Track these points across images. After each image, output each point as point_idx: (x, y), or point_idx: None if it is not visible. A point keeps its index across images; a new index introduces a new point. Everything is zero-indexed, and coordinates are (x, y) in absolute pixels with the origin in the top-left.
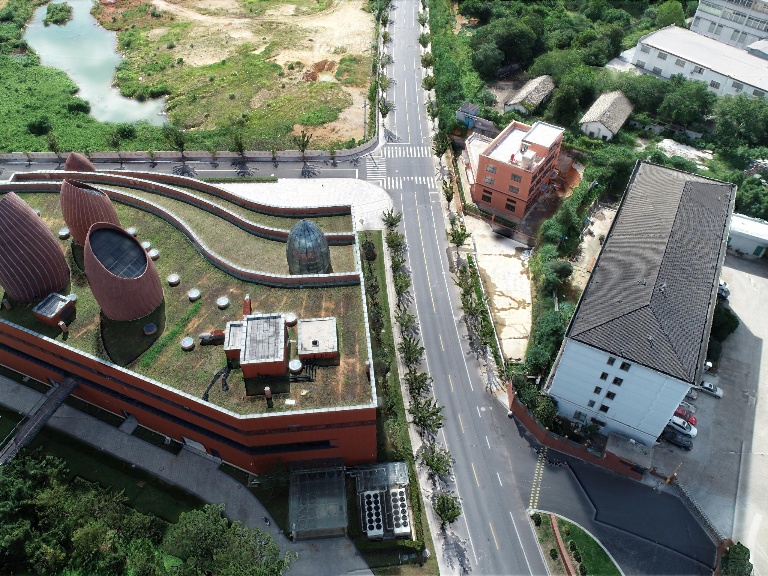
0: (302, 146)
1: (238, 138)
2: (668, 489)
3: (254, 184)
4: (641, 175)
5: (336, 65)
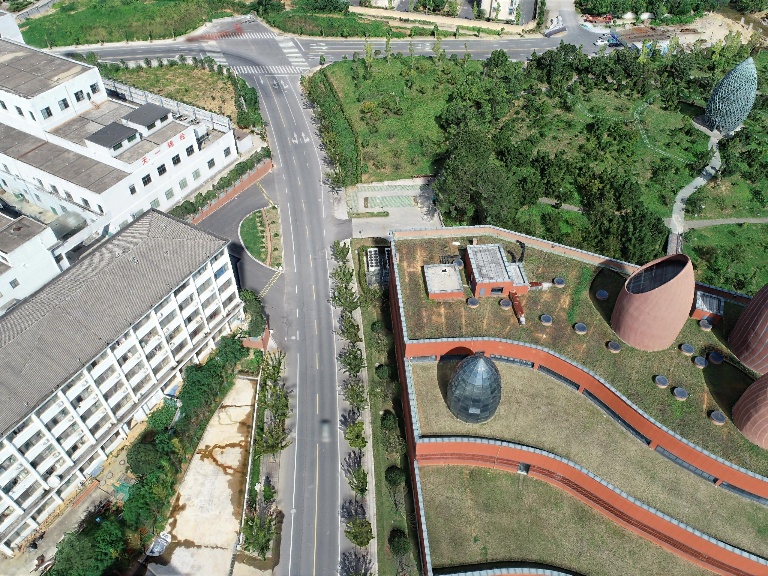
0: None
1: None
2: None
3: None
4: None
5: None
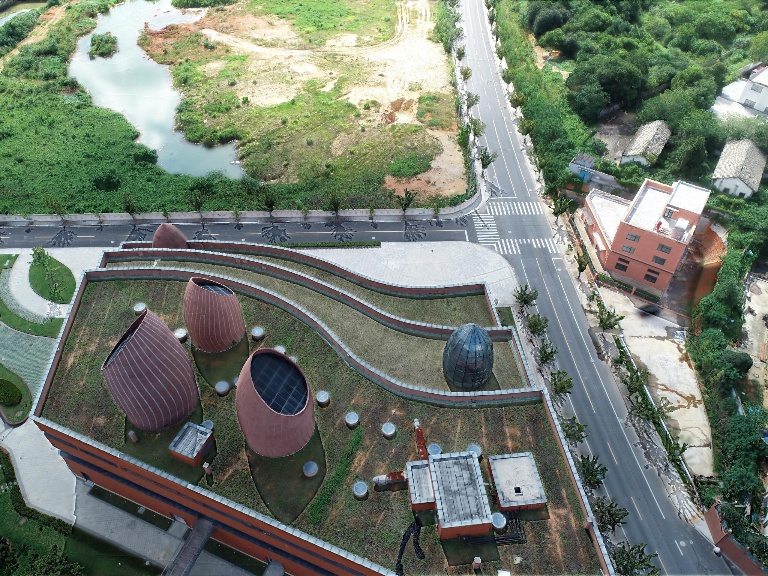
0: (405, 205)
1: (335, 197)
2: None
3: (356, 250)
4: None
5: (414, 104)
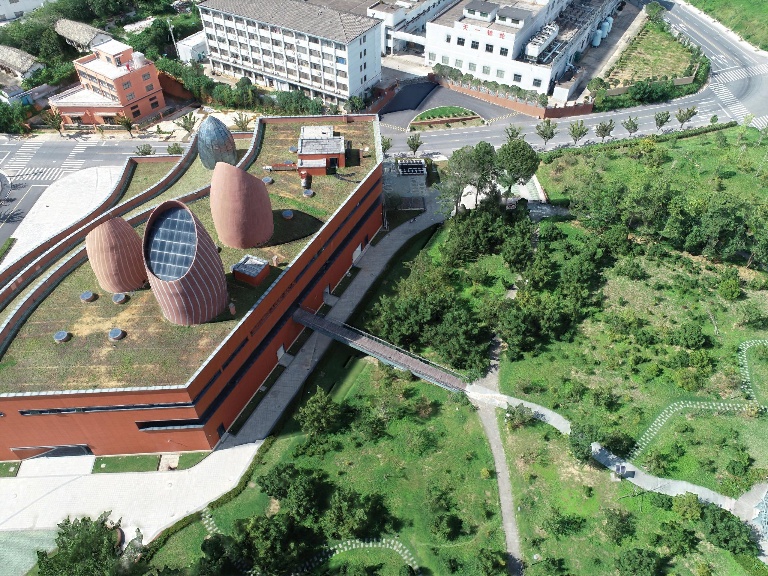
0: None
1: None
2: (401, 87)
3: (8, 256)
4: (214, 5)
5: None
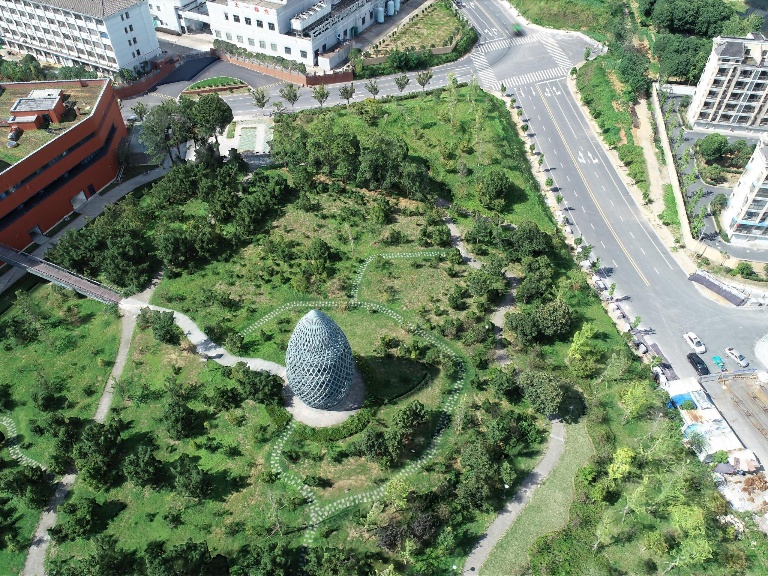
0: None
1: None
2: (183, 61)
3: None
4: None
5: None
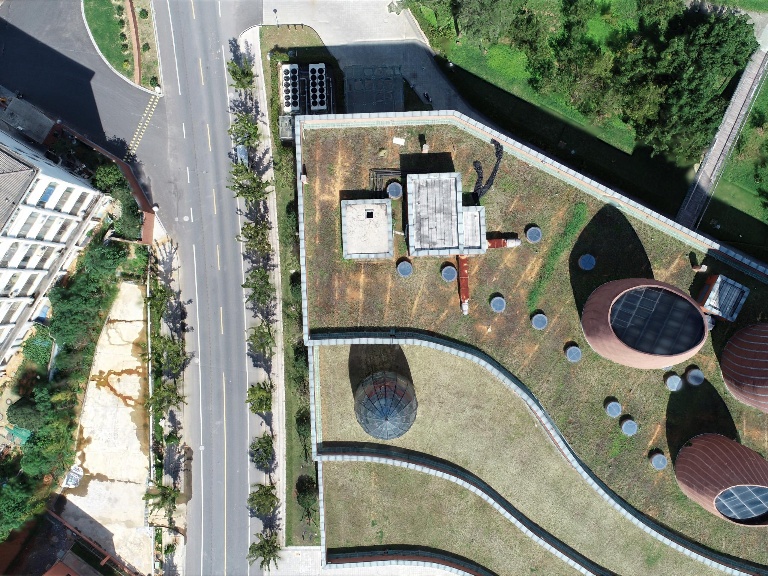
0: None
1: None
2: (6, 94)
3: None
4: None
5: None
